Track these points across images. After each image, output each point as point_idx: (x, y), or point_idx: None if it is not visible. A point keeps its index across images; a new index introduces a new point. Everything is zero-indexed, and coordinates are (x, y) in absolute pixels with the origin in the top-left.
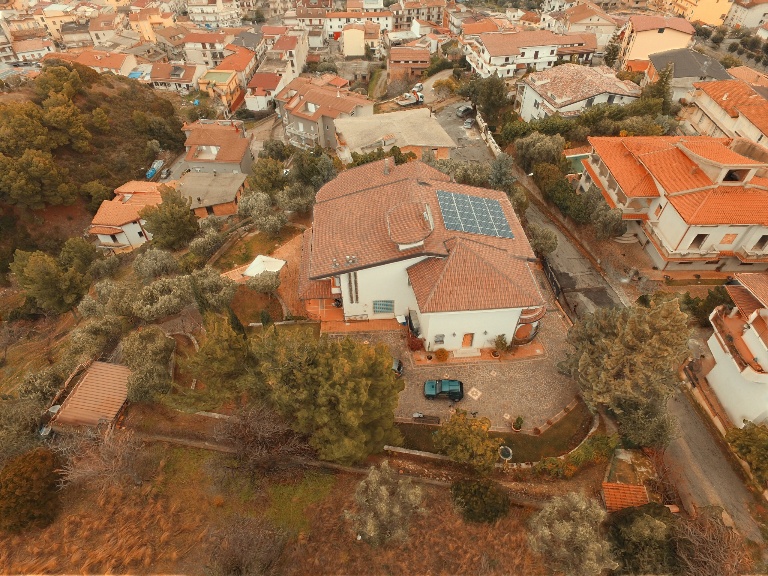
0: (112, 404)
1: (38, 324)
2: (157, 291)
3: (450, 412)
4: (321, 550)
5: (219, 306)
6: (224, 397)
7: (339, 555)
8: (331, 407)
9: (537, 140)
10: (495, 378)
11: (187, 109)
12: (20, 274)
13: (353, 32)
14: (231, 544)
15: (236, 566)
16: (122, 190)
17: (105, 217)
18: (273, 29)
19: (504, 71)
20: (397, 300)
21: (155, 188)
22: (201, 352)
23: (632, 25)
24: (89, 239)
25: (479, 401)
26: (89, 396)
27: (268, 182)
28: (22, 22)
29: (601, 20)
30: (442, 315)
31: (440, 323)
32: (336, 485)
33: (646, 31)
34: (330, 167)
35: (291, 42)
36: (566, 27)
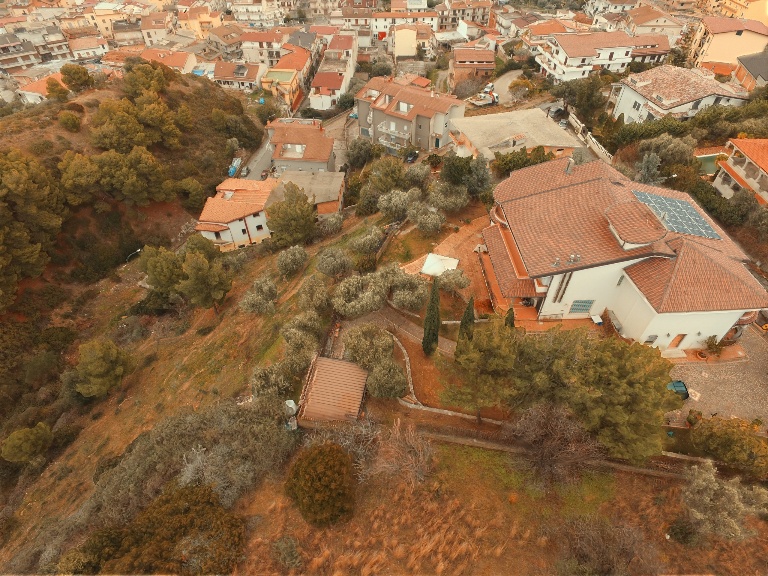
0: (351, 400)
1: (165, 319)
2: (354, 288)
3: (676, 413)
4: (639, 549)
5: (419, 304)
6: (503, 394)
7: (656, 554)
8: (625, 406)
9: (666, 141)
10: (708, 379)
11: (254, 108)
12: (153, 269)
13: (405, 32)
14: (596, 541)
15: (606, 563)
16: (224, 187)
17: (212, 214)
18: (322, 29)
19: (580, 72)
20: (598, 300)
21: (257, 186)
22: (473, 349)
23: (706, 27)
24: (186, 236)
25: (701, 402)
26: (327, 391)
27: (392, 181)
28: (73, 20)
29: (668, 22)
30: (671, 315)
31: (660, 323)
32: (618, 484)
33: (724, 33)
34: (485, 166)
35: (347, 42)
36: (630, 29)
